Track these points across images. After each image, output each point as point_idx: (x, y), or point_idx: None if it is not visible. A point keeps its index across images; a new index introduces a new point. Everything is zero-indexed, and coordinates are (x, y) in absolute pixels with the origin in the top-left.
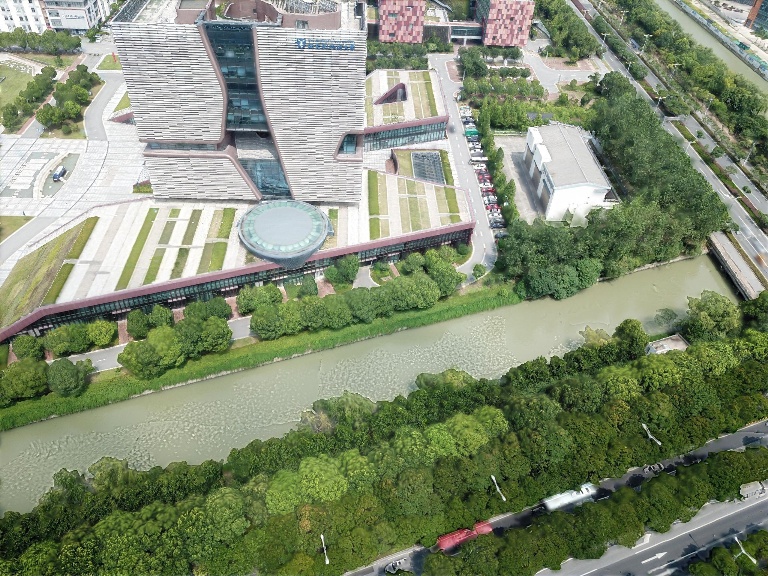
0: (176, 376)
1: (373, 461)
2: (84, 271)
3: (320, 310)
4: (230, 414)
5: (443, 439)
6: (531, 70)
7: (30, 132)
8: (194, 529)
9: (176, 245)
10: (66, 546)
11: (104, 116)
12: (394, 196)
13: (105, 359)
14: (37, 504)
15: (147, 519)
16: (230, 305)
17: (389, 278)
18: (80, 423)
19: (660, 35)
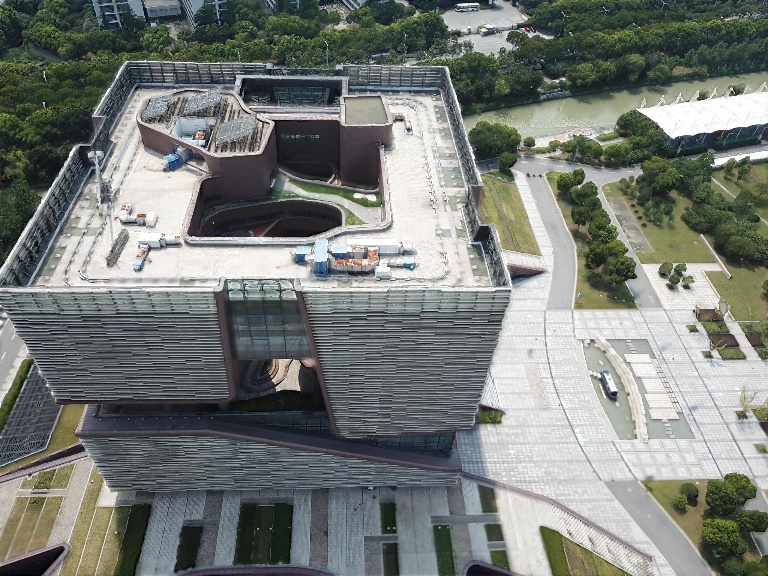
0: None
1: None
2: None
3: None
4: None
5: None
6: None
7: (756, 499)
8: None
9: None
10: None
11: (672, 573)
12: None
13: None
14: None
15: None
16: None
17: None
18: None
19: None
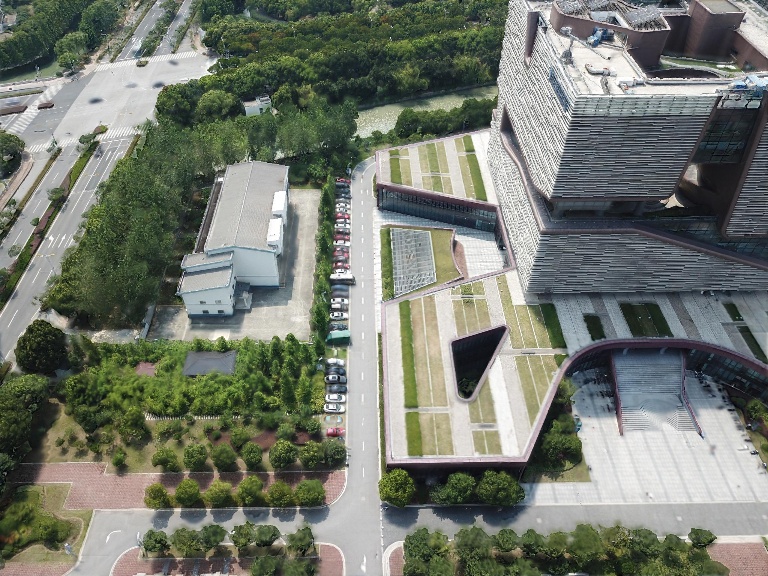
0: None
1: None
2: None
3: None
4: None
5: None
6: None
7: None
8: None
9: None
10: None
11: None
12: (454, 174)
13: None
14: None
15: None
16: None
17: None
18: None
19: None
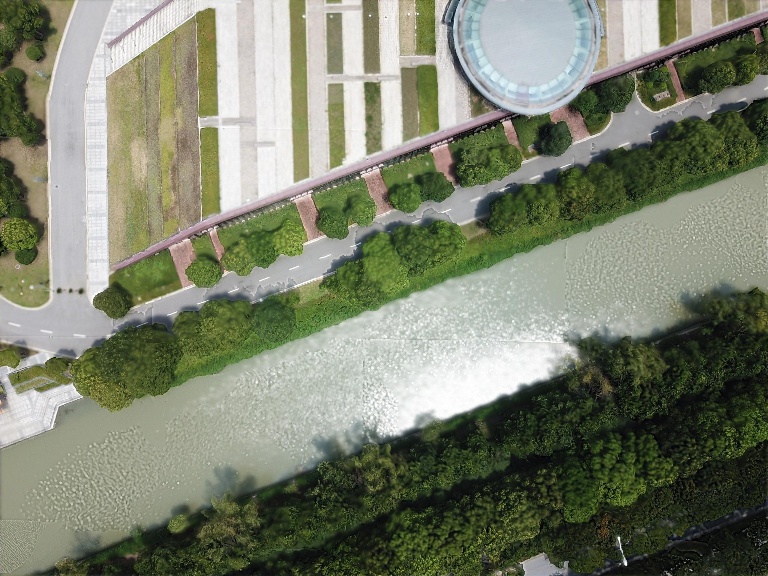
0: (397, 294)
1: (677, 463)
2: (236, 142)
3: (589, 204)
4: (462, 326)
5: (761, 436)
6: None
7: None
8: (494, 545)
9: (356, 75)
10: (377, 575)
11: None
12: None
13: (298, 266)
14: (286, 451)
15: (445, 538)
16: (442, 165)
17: (665, 94)
18: (293, 348)
19: None
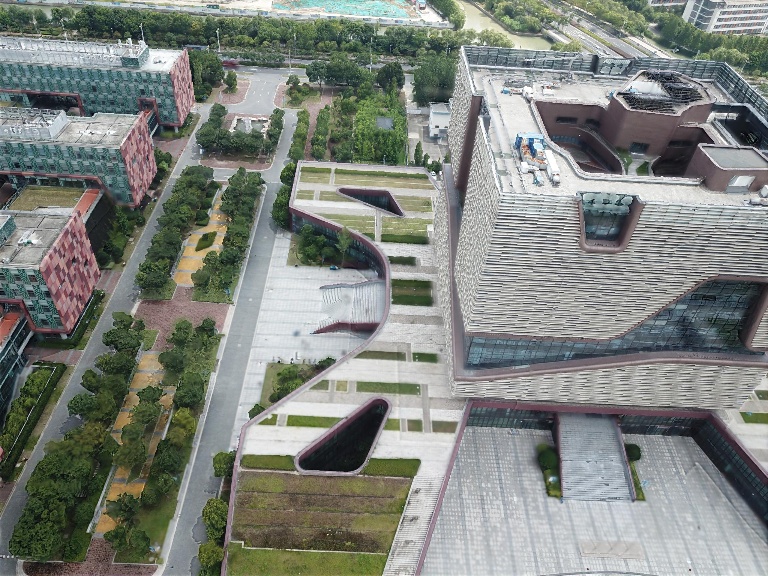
0: None
1: None
2: None
3: None
4: None
5: None
6: (243, 115)
7: None
8: None
9: None
10: None
11: None
12: None
13: None
14: None
15: None
16: None
17: None
18: None
19: (210, 26)
